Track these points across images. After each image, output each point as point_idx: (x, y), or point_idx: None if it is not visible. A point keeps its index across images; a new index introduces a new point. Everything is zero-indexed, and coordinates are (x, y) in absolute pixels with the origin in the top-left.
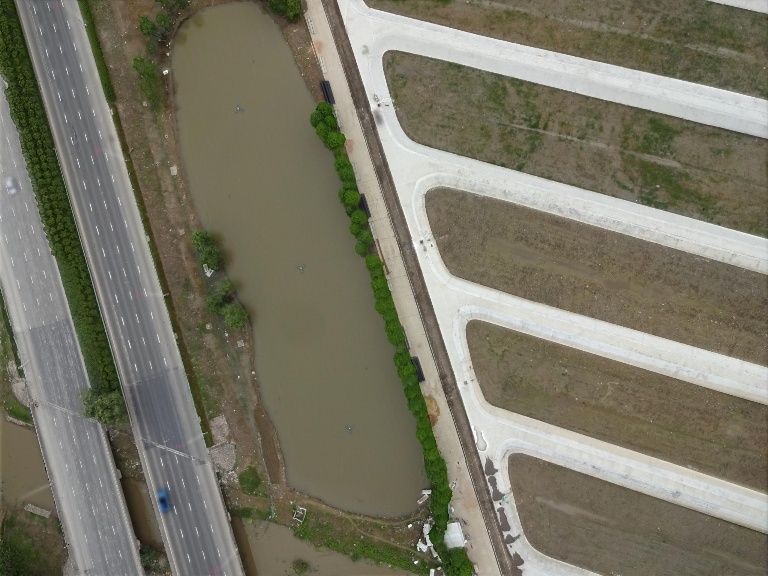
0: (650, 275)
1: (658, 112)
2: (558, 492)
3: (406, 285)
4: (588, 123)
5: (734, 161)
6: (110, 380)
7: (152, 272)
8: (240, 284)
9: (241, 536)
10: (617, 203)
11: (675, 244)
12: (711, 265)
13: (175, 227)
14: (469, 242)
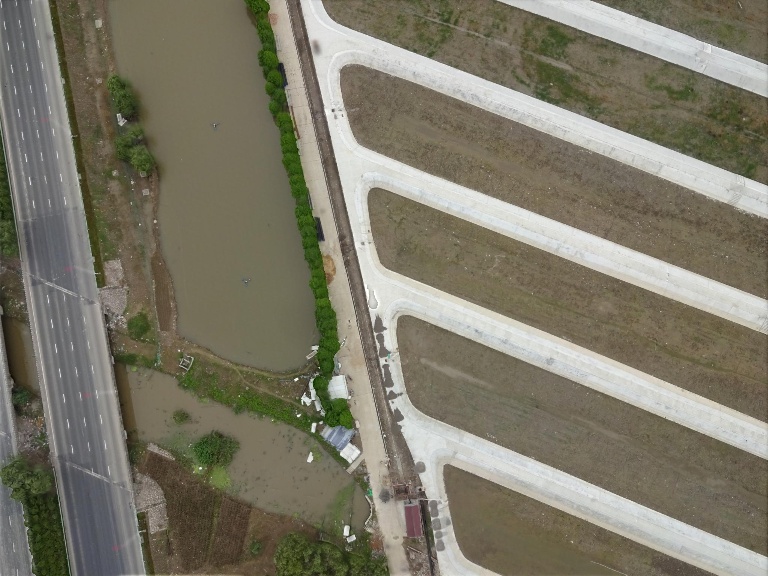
0: (540, 161)
1: (555, 20)
2: (442, 355)
3: (315, 151)
4: (494, 23)
5: (618, 70)
6: (4, 211)
7: (63, 114)
8: (152, 139)
9: (123, 383)
10: (514, 94)
11: (563, 135)
12: (593, 157)
13: (93, 76)
14: (378, 117)
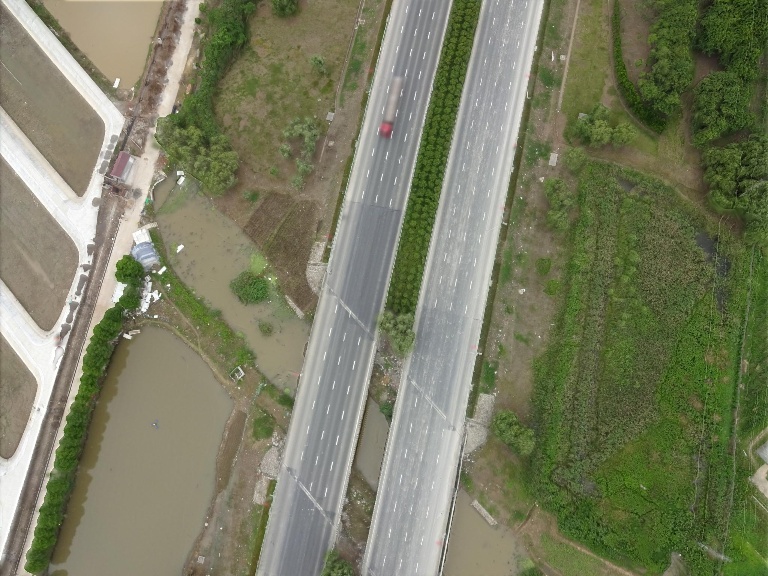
0: None
1: None
2: (35, 284)
3: (35, 523)
4: None
5: None
6: None
7: None
8: None
9: None
10: None
11: None
12: None
13: None
14: None
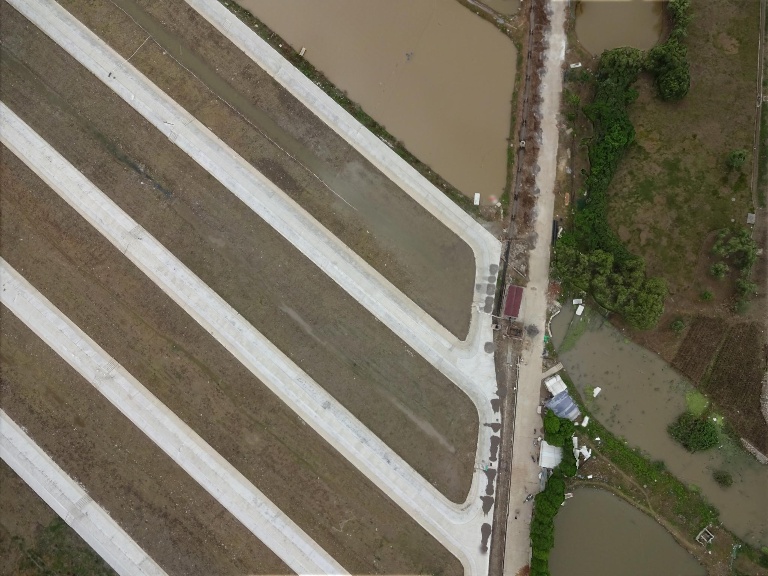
0: None
1: None
2: (431, 448)
3: None
4: None
5: None
6: None
7: None
8: None
9: None
10: None
11: None
12: None
13: None
14: None
